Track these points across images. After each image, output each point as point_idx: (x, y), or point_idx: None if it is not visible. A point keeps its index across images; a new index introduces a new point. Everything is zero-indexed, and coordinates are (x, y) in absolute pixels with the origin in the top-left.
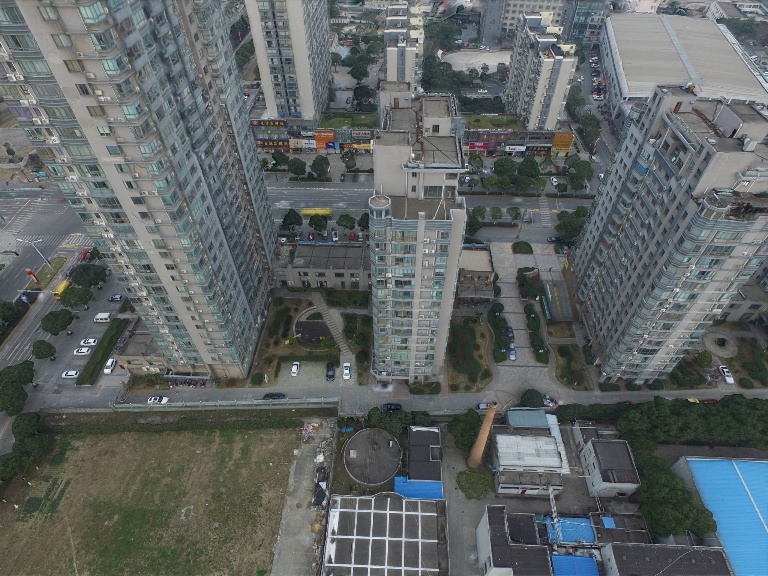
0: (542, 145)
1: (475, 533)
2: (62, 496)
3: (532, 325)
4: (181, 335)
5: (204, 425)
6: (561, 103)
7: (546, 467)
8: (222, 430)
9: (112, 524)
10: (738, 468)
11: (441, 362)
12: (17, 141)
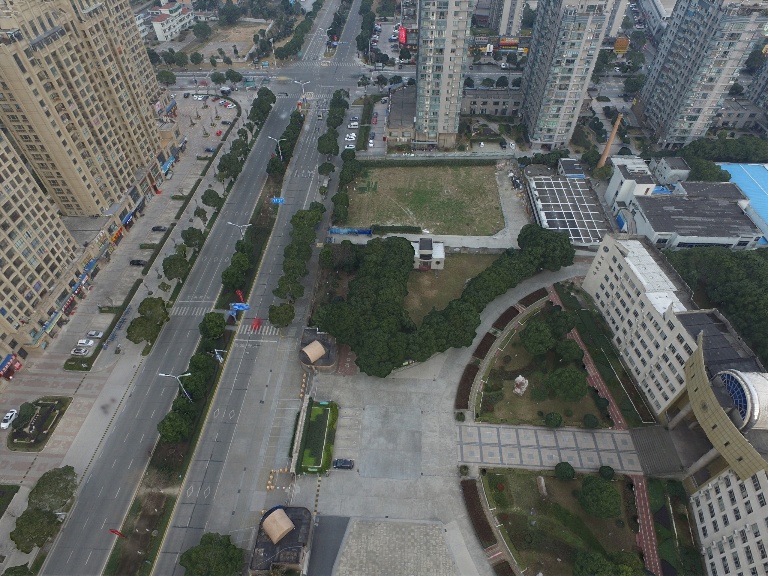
0: (607, 48)
1: (604, 197)
2: (377, 186)
3: (619, 126)
4: (435, 106)
5: (443, 161)
6: (622, 16)
7: (640, 167)
8: (450, 166)
9: (410, 195)
10: (742, 166)
11: (571, 135)
12: (230, 48)
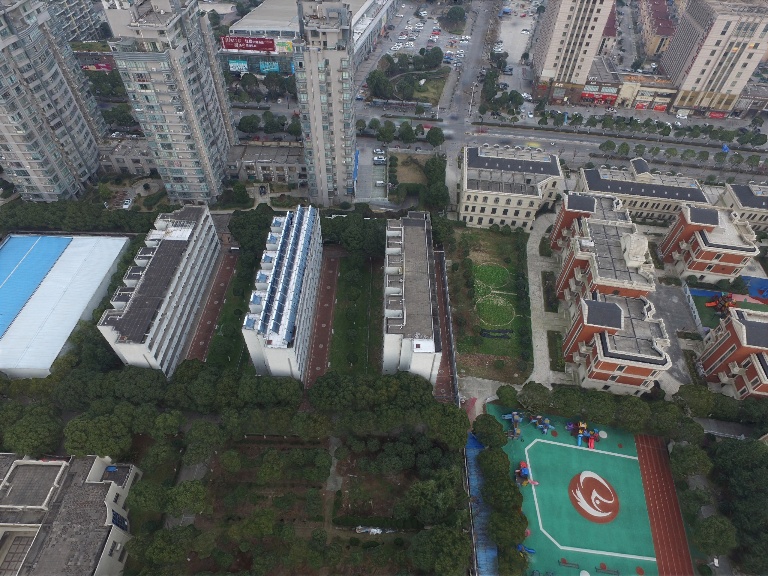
0: None
1: None
2: None
3: None
4: None
5: None
6: None
7: None
8: None
9: None
10: (39, 240)
11: None
12: None
